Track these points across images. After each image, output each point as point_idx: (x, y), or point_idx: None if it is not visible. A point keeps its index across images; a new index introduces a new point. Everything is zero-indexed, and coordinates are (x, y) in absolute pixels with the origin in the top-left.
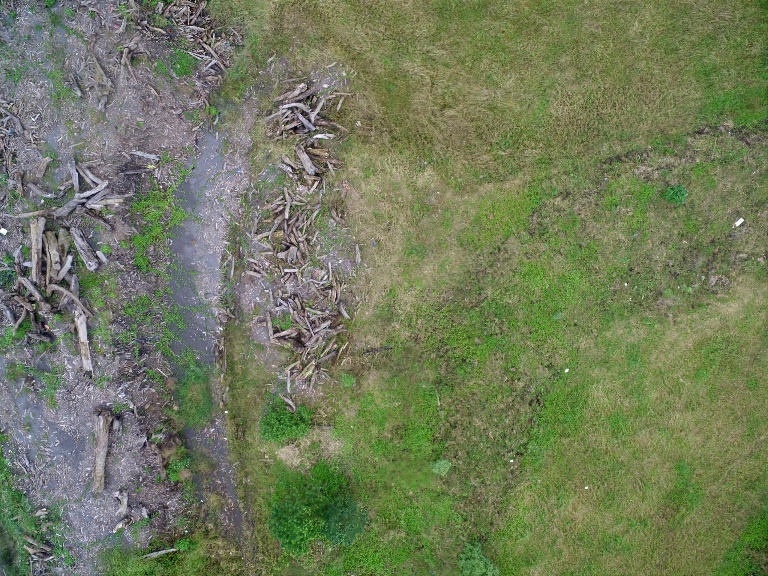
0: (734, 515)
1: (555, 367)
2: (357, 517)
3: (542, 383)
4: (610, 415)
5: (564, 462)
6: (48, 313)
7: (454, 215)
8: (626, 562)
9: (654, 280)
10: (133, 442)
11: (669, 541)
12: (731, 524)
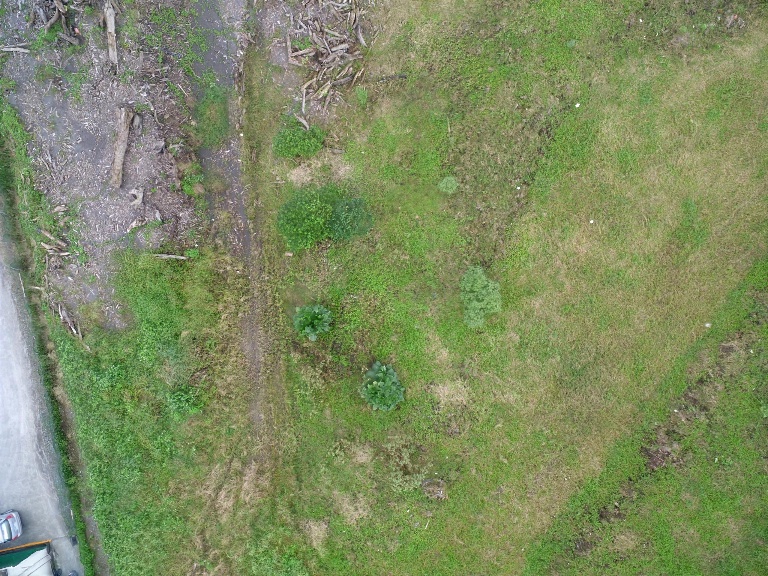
0: (739, 257)
1: (566, 100)
2: (364, 213)
3: (552, 114)
4: (619, 150)
5: (570, 196)
6: (79, 6)
7: None
8: (628, 297)
9: (669, 17)
10: (151, 144)
11: (672, 278)
12: (736, 266)
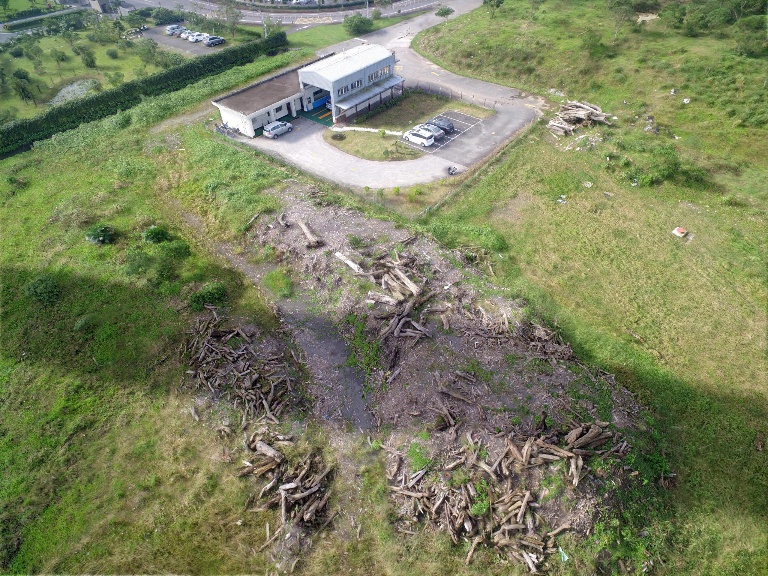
0: None
1: None
2: None
3: None
4: None
5: None
6: None
7: (111, 498)
8: None
9: None
10: (295, 244)
11: None
12: None
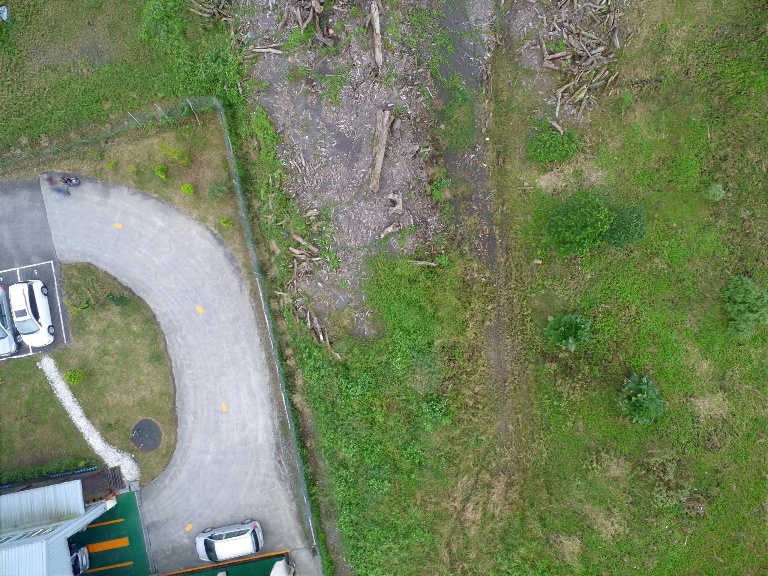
0: None
1: None
2: None
3: None
4: None
5: None
6: (344, 6)
7: None
8: None
9: None
10: (408, 148)
11: None
12: None
